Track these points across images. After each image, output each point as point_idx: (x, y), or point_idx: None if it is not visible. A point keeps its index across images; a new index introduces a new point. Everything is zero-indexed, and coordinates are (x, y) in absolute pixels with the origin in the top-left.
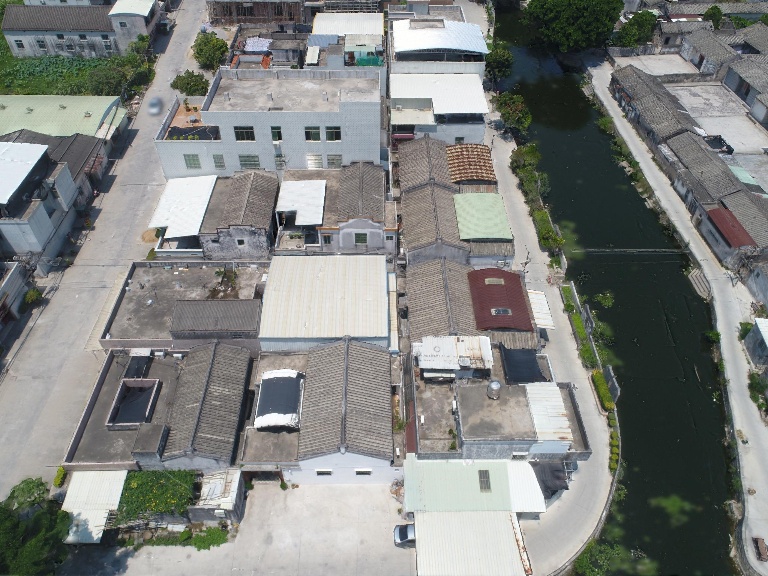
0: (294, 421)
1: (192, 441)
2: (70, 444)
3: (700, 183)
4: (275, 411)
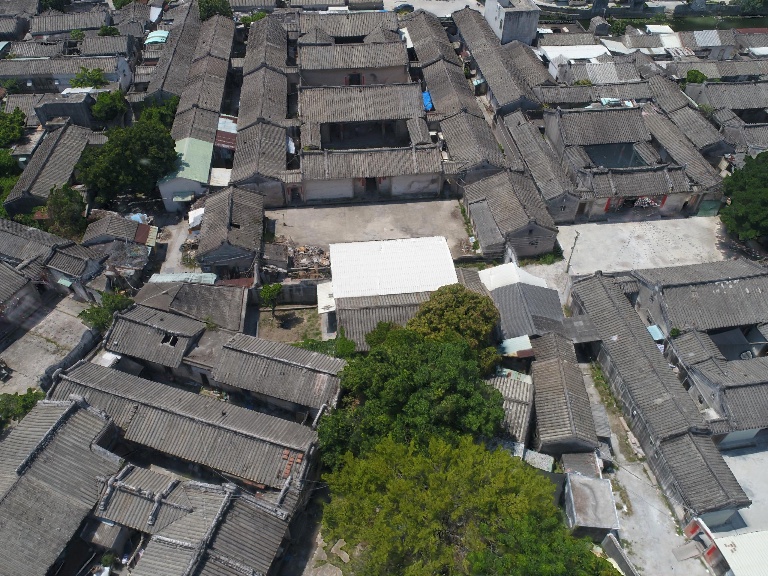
0: None
1: None
2: None
3: None
4: None
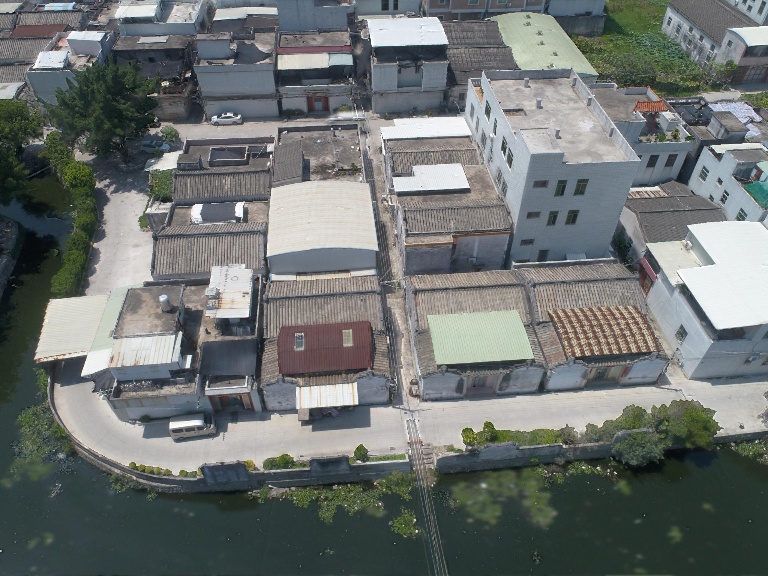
0: (196, 221)
1: (181, 174)
2: (199, 139)
3: None
4: (203, 208)
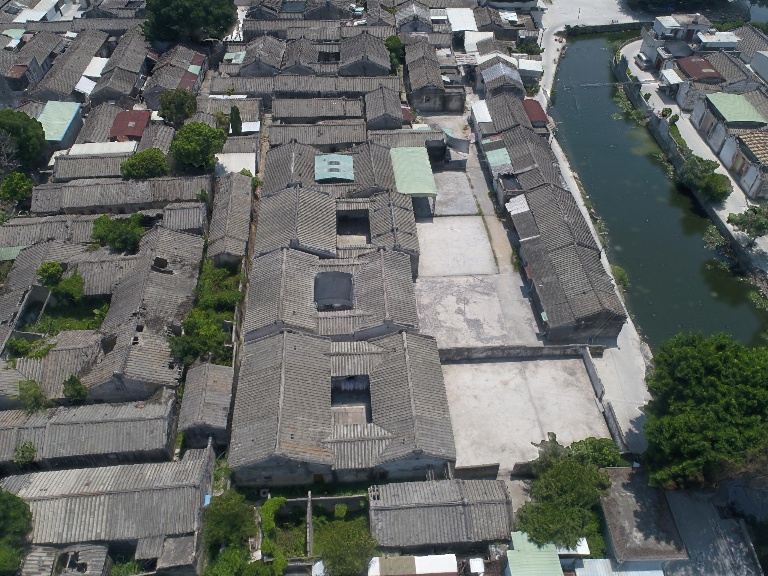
0: None
1: None
2: None
3: (544, 148)
4: None
